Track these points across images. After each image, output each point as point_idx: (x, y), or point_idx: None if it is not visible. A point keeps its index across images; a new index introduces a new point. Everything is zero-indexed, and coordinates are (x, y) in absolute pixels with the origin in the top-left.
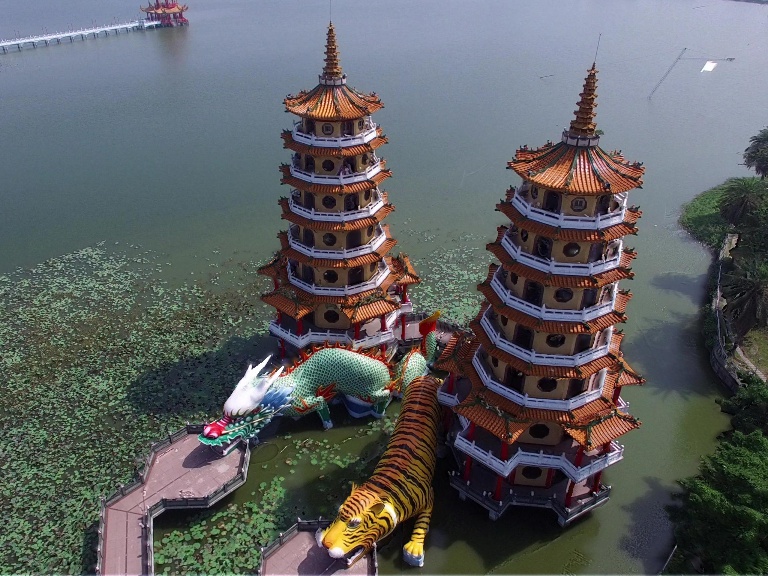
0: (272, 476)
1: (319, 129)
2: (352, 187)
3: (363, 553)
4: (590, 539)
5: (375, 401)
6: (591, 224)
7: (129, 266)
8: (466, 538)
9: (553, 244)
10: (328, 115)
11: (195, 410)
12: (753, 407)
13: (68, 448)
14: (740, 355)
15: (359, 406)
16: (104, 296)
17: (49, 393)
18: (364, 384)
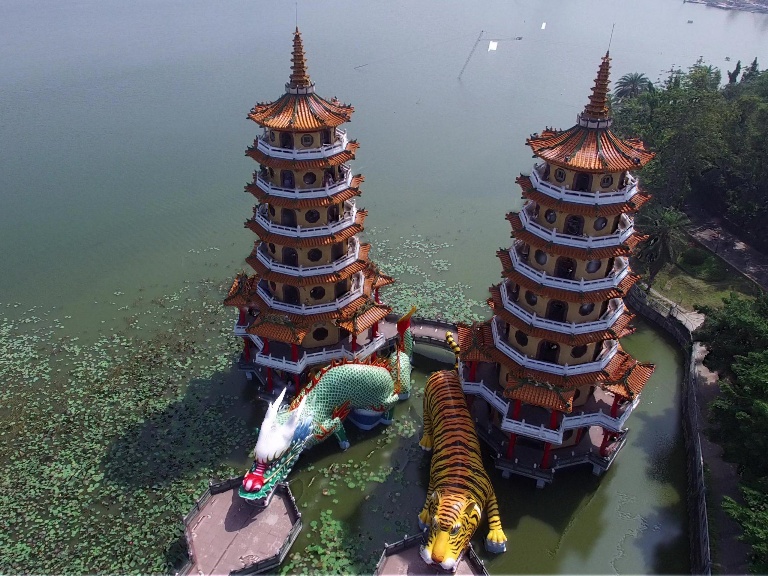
0: (318, 512)
1: (298, 141)
2: (338, 197)
3: (462, 556)
4: (622, 479)
5: (387, 408)
6: (621, 198)
7: (18, 329)
8: (528, 512)
9: (585, 221)
10: (312, 126)
11: (195, 469)
12: (726, 331)
13: (66, 554)
14: (653, 292)
15: (371, 418)
16: (7, 370)
17: (2, 499)
18: (377, 394)
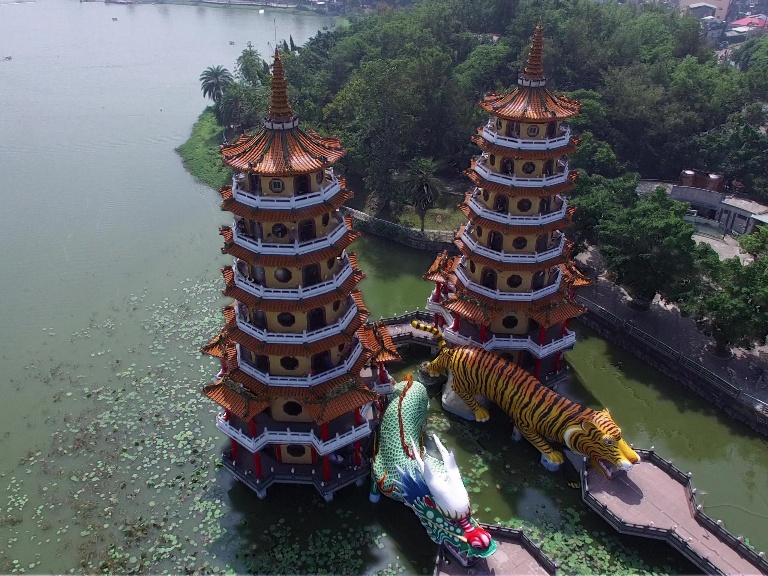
0: None
1: (315, 181)
2: None
3: None
4: None
5: None
6: None
7: None
8: None
9: (554, 162)
10: (336, 156)
11: None
12: None
13: None
14: None
15: None
16: None
17: None
18: None
